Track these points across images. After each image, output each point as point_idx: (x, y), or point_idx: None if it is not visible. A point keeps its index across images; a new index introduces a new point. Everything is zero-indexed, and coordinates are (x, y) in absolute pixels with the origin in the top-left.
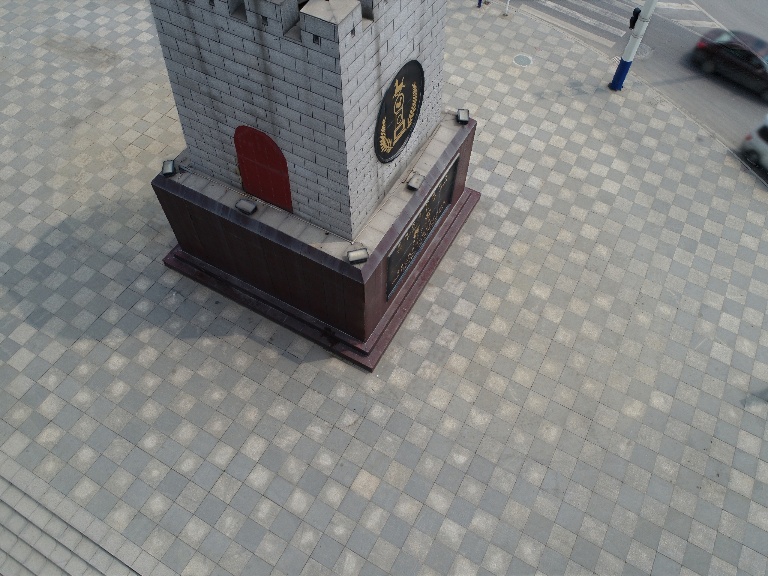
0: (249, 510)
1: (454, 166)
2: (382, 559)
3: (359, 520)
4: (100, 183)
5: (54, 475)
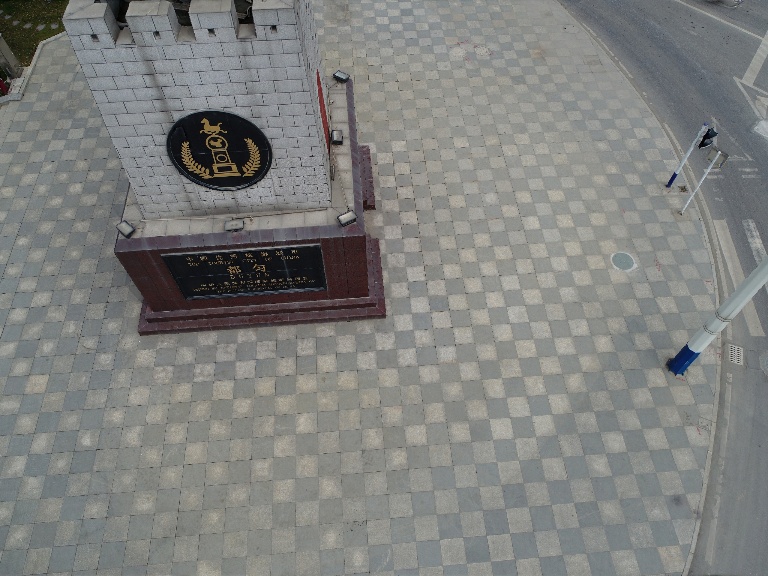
0: None
1: (316, 253)
2: None
3: (5, 395)
4: None
5: None
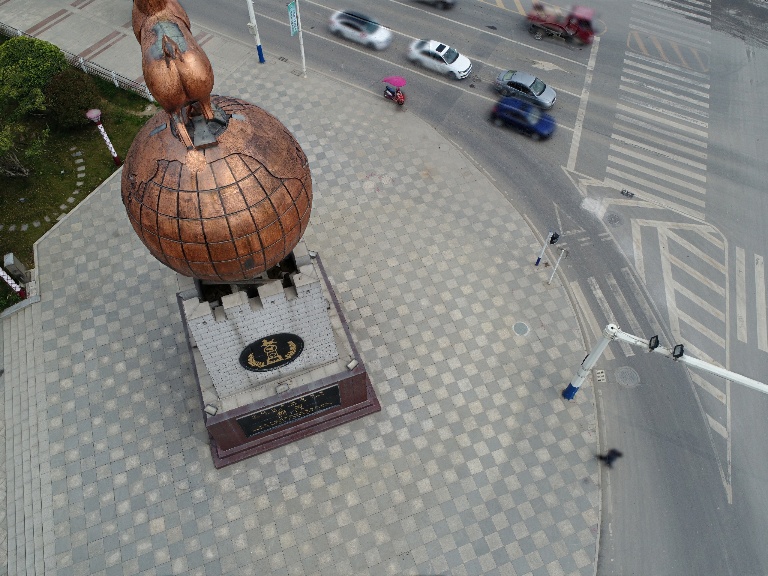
0: (102, 492)
1: (335, 388)
2: (128, 569)
3: (137, 541)
4: None
5: (52, 405)
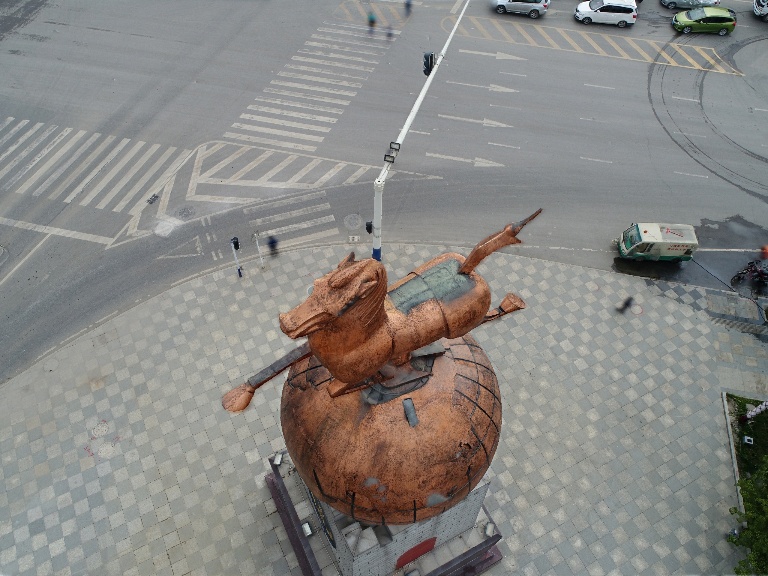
0: None
1: None
2: None
3: None
4: None
5: None
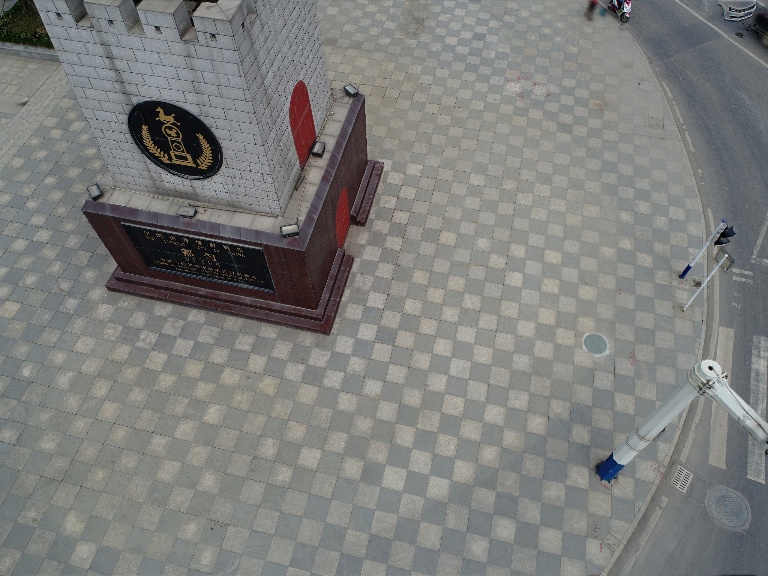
0: None
1: None
2: None
3: None
4: None
5: (29, 145)
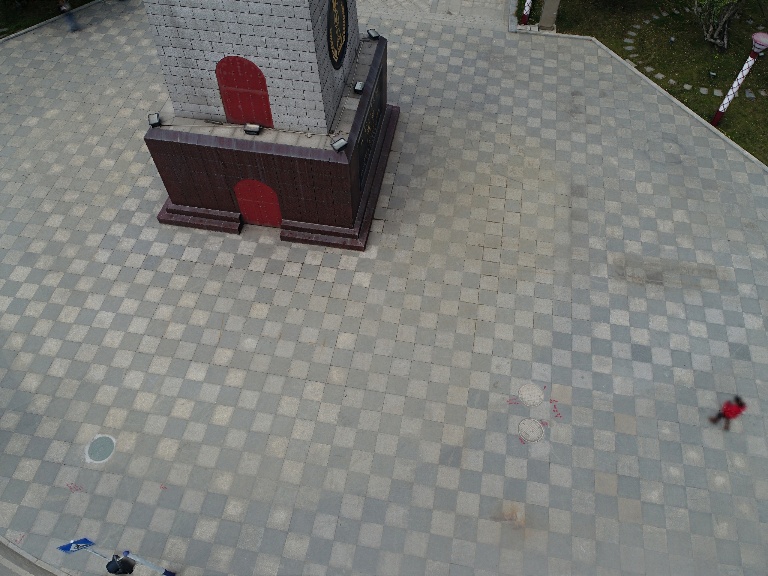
0: None
1: None
2: None
3: None
4: (499, 150)
5: (382, 21)
